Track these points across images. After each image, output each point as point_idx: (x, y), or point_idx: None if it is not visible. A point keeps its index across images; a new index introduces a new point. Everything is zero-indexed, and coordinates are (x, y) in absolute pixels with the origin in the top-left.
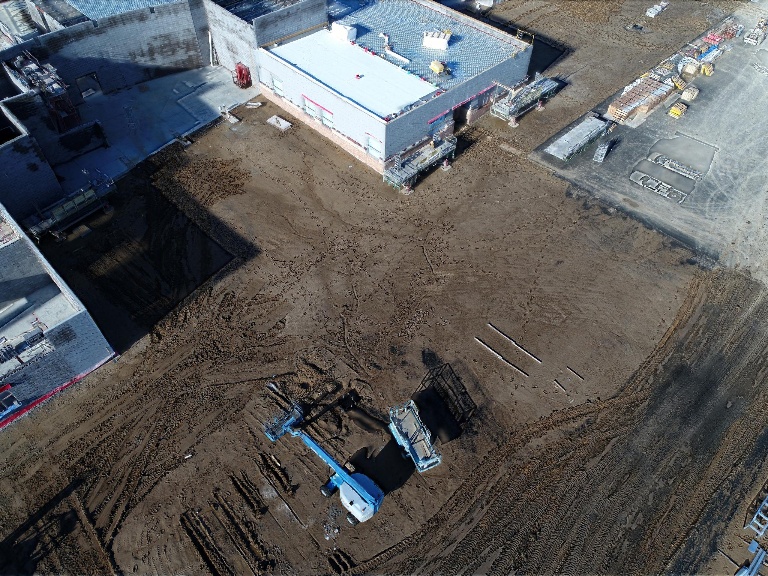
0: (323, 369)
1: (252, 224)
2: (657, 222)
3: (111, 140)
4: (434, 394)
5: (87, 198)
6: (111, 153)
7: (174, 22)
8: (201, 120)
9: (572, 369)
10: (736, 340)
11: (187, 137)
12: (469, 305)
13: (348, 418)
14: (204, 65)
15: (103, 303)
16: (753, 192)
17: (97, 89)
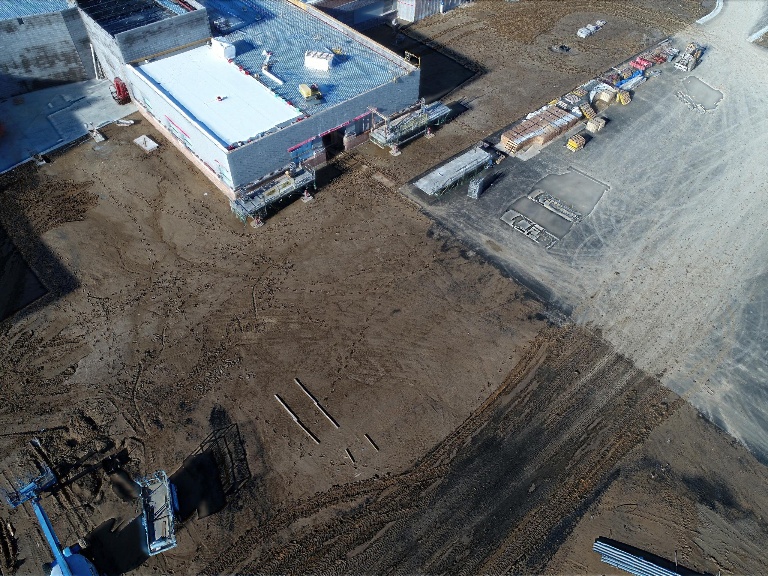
0: (99, 424)
1: (80, 255)
2: (515, 269)
3: None
4: (209, 459)
5: None
6: None
7: (48, 34)
8: (65, 138)
9: (370, 437)
10: (563, 411)
11: (45, 156)
12: (281, 357)
13: (108, 482)
14: (89, 78)
15: None
16: (633, 238)
17: None
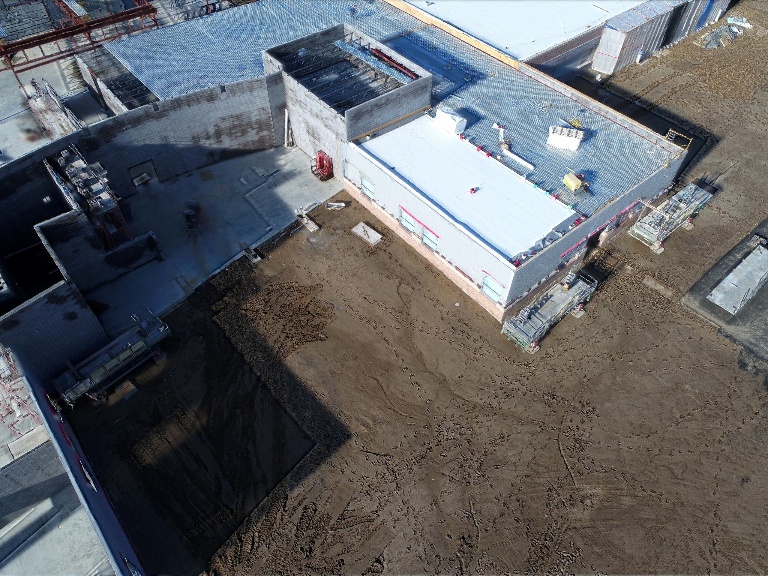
0: None
1: (337, 390)
2: None
3: (166, 250)
4: None
5: (135, 351)
6: (166, 270)
7: (247, 101)
8: (273, 225)
9: None
10: None
11: (256, 249)
12: (629, 549)
13: None
14: (277, 145)
15: (148, 512)
16: None
17: (152, 174)
